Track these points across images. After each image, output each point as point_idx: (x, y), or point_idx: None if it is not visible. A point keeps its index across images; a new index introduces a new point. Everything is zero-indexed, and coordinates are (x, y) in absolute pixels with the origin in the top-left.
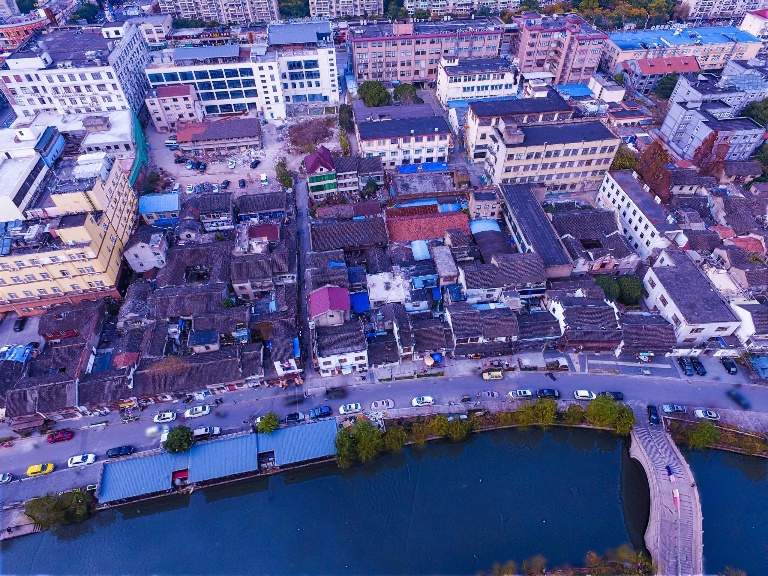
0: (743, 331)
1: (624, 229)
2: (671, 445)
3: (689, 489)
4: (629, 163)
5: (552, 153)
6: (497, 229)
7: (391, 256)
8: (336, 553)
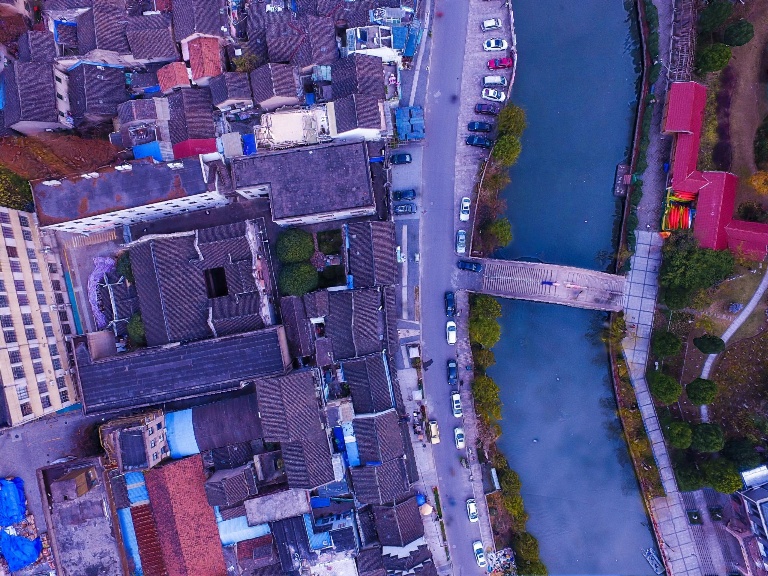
0: (370, 136)
1: (164, 215)
2: (507, 262)
3: (563, 271)
4: (1, 174)
5: (7, 331)
6: (188, 416)
7: (254, 570)
8: (607, 570)
